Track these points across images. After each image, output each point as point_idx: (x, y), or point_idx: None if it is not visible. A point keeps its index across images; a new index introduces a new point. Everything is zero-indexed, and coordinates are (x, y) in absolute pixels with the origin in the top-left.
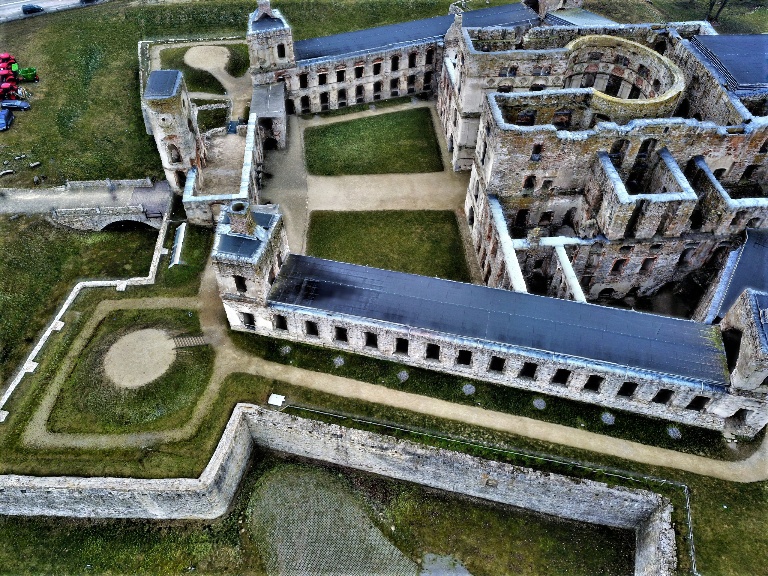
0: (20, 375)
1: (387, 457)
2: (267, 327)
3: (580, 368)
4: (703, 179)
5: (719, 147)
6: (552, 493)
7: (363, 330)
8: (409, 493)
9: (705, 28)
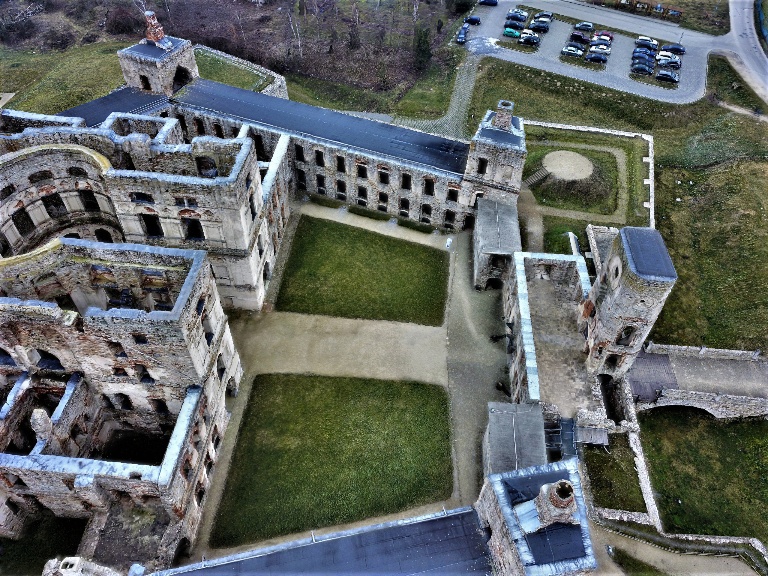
0: (652, 177)
1: None
2: None
3: None
4: None
5: None
6: None
7: None
8: None
9: None
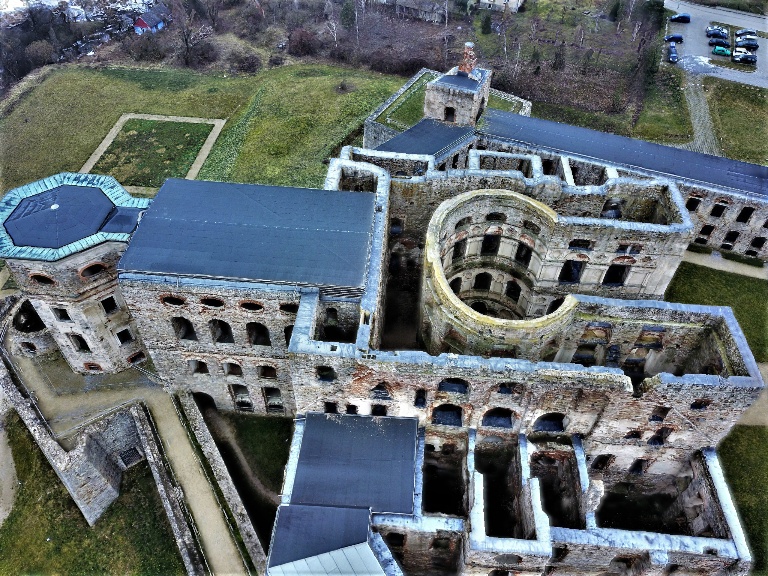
0: None
1: None
2: None
3: None
4: None
5: None
6: None
7: None
8: None
9: None
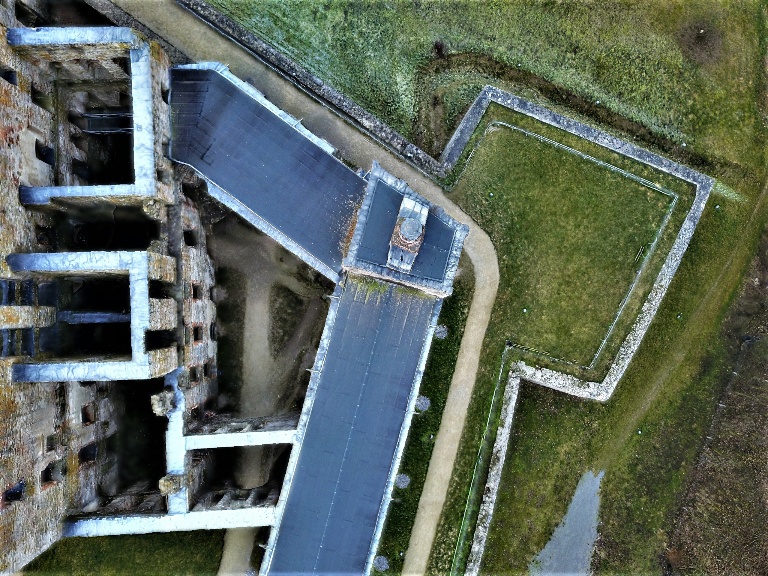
0: None
1: None
2: None
3: None
4: None
5: (8, 160)
6: None
7: None
8: None
9: None
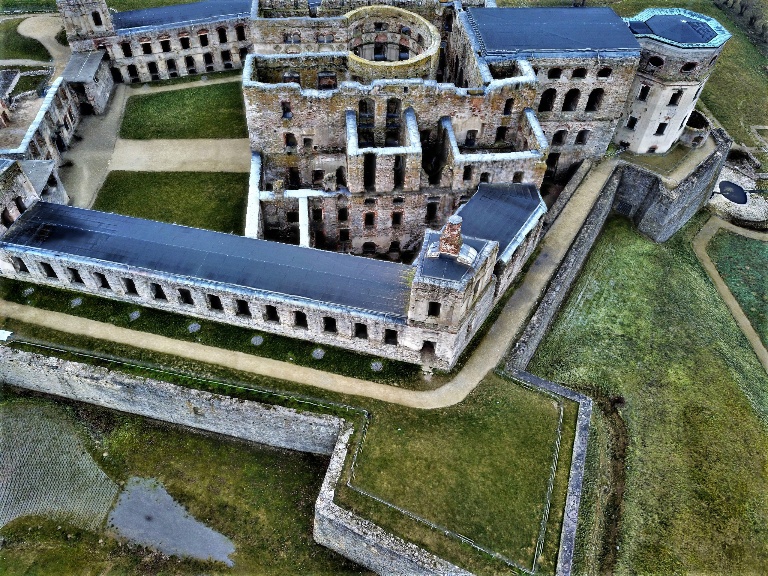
0: None
1: (103, 388)
2: (10, 270)
3: (280, 303)
4: (447, 138)
5: (463, 108)
6: (249, 419)
7: (90, 270)
8: (131, 424)
9: (487, 2)
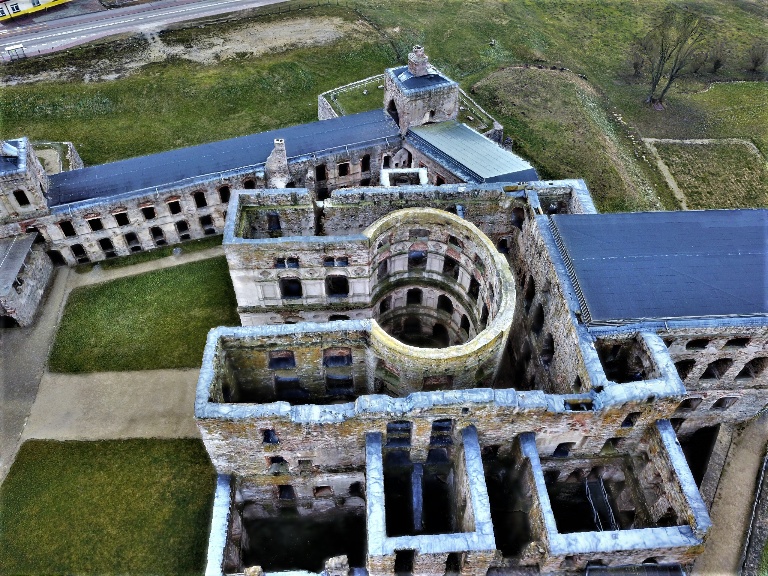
0: None
1: None
2: None
3: None
4: (530, 475)
5: (556, 424)
6: None
7: None
8: None
9: (576, 194)
